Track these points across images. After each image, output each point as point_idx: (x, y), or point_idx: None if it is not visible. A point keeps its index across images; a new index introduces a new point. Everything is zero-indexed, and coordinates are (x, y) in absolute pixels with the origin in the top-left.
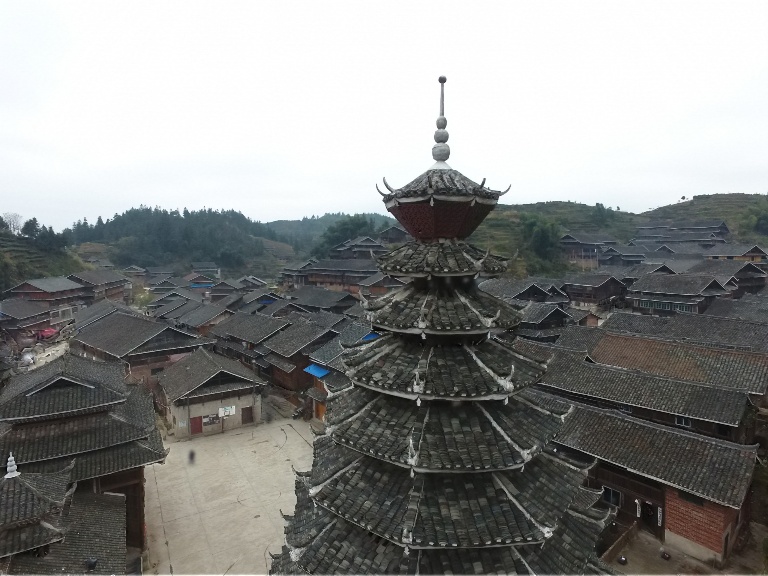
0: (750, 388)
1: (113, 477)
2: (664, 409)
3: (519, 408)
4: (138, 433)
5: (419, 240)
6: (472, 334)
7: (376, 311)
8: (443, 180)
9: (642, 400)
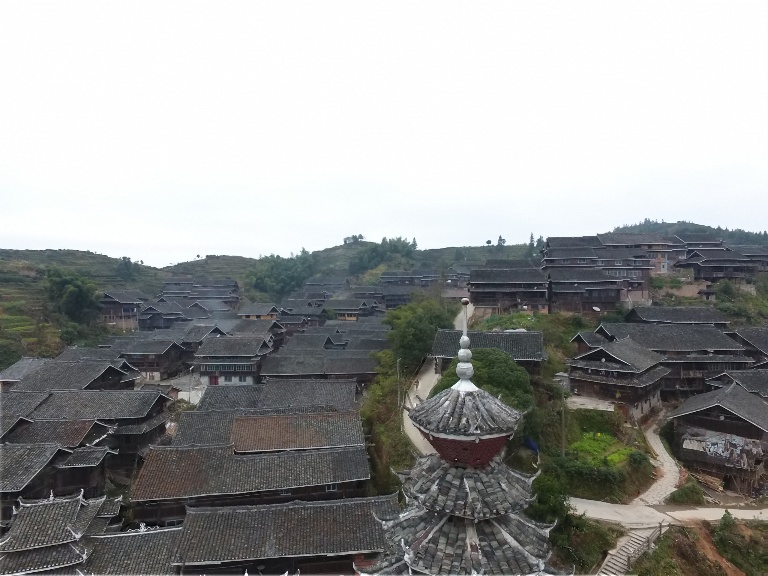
0: (356, 442)
1: None
2: (320, 482)
3: None
4: None
5: (472, 467)
6: None
7: None
8: None
9: (301, 480)
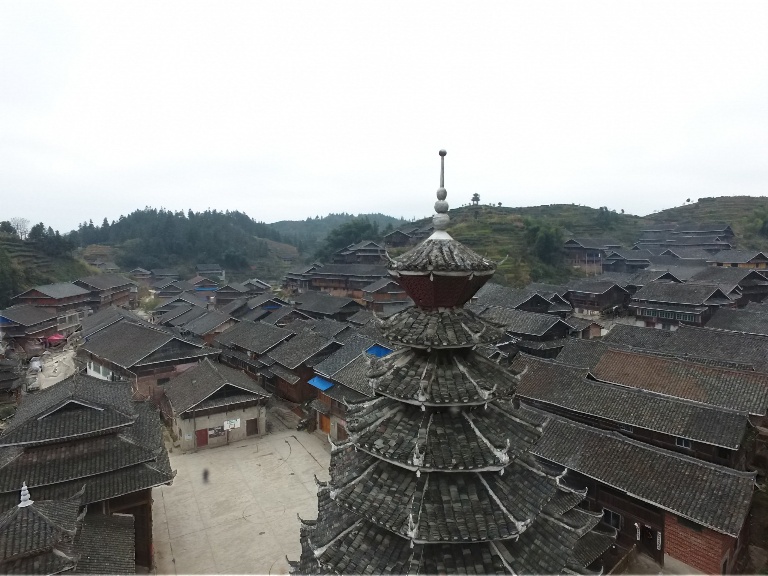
0: (750, 409)
1: (122, 498)
2: (664, 430)
3: (515, 470)
4: (146, 455)
5: (419, 307)
6: (470, 405)
7: (378, 378)
8: (442, 253)
9: (643, 420)
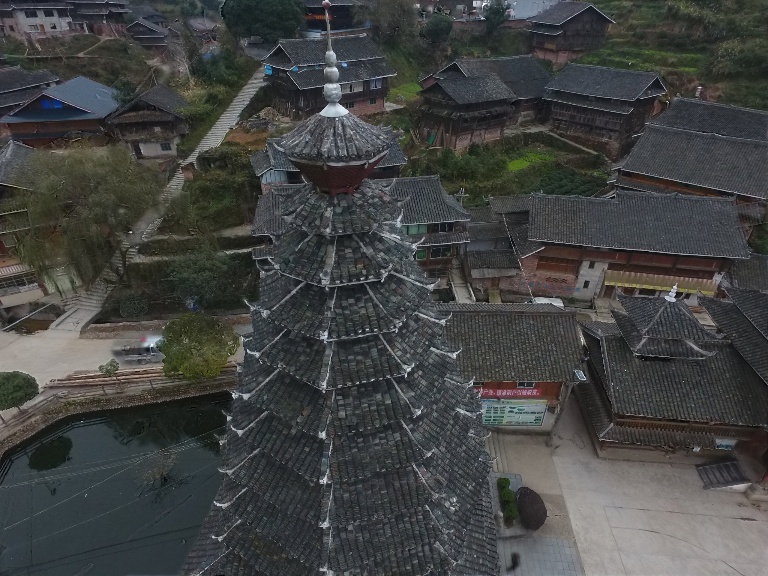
0: None
1: None
2: None
3: None
4: None
5: None
6: None
7: None
8: None
9: None
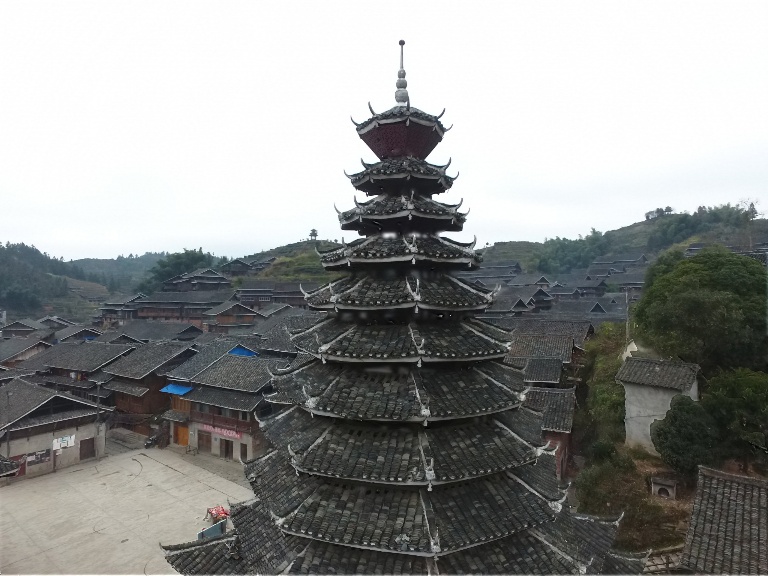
0: None
1: None
2: None
3: None
4: None
5: (390, 158)
6: (442, 219)
7: (364, 206)
8: None
9: None
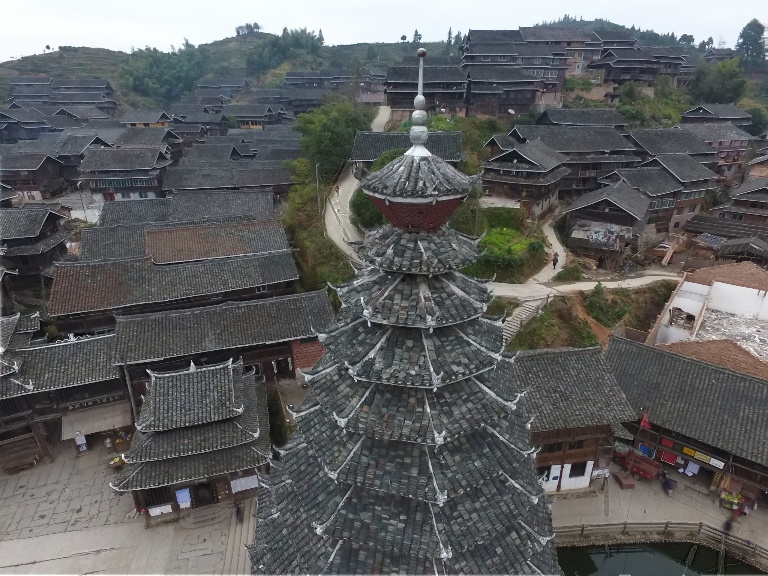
0: (281, 247)
1: None
2: (250, 285)
3: None
4: None
5: (425, 231)
6: None
7: None
8: None
9: (230, 284)
